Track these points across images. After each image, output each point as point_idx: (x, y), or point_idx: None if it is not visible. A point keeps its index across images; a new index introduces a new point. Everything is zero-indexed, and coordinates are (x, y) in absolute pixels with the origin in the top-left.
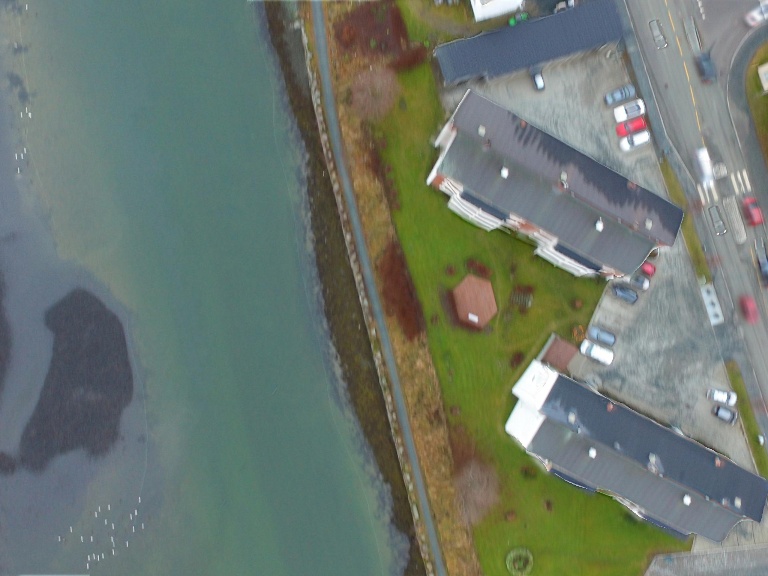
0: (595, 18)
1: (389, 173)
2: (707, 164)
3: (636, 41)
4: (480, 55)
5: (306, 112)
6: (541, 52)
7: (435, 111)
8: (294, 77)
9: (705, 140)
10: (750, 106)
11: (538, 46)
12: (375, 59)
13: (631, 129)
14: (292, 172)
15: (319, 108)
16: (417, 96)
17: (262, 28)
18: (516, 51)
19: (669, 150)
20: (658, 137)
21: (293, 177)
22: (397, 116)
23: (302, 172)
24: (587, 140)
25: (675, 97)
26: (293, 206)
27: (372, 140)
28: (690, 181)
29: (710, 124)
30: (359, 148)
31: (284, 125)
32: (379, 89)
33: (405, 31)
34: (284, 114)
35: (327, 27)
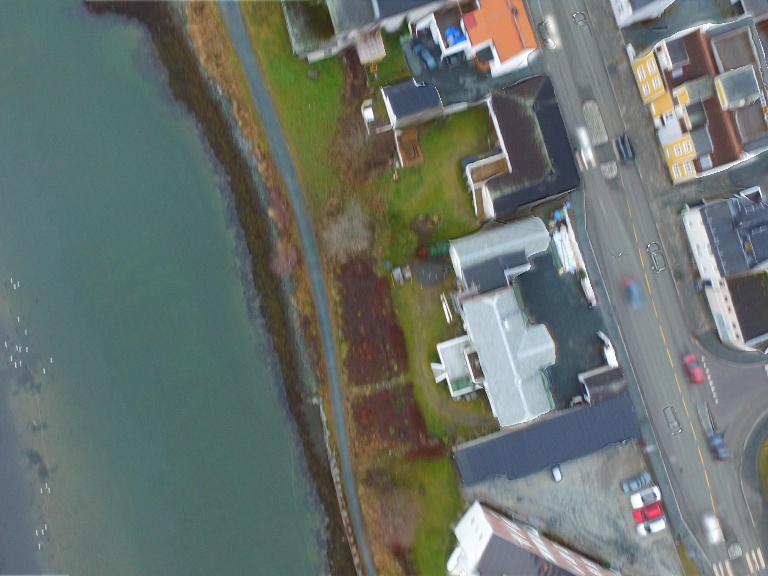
0: (611, 418)
1: (409, 555)
2: (722, 545)
3: (651, 428)
4: (499, 458)
5: (325, 480)
6: (559, 454)
7: (454, 501)
8: (313, 446)
9: (720, 521)
10: (763, 487)
11: (556, 448)
12: (394, 444)
13: (648, 517)
14: (312, 534)
15: (339, 485)
16: (436, 484)
17: (280, 396)
18: (534, 454)
19: (685, 533)
20: (674, 521)
21: (313, 539)
22: (417, 501)
23: (322, 535)
24: (604, 524)
25: (690, 481)
26: (313, 567)
27: (392, 525)
28: (706, 562)
29: (724, 506)
30: (379, 527)
31: (303, 489)
32: (398, 474)
33: (424, 425)
34: (303, 479)
35: (345, 406)
